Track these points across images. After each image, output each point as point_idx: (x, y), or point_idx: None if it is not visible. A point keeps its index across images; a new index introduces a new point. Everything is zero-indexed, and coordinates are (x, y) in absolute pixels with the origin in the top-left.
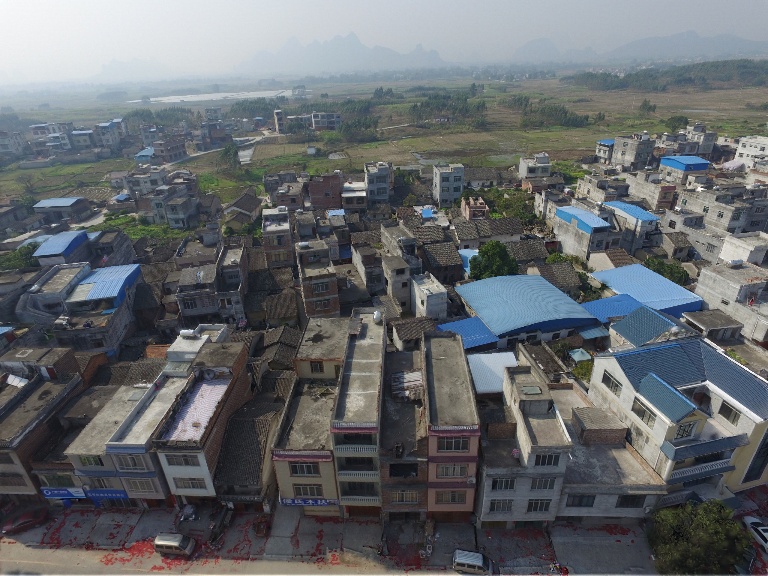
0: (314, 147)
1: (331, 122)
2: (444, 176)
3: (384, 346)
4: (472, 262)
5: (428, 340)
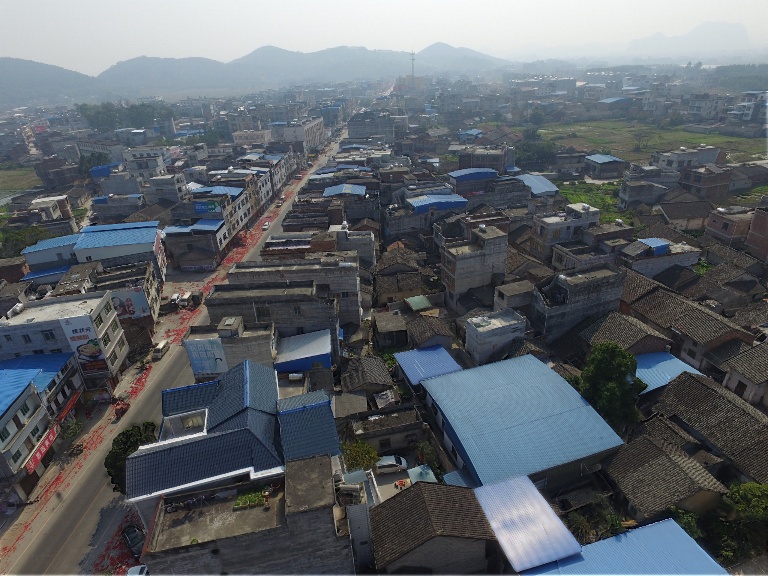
0: None
1: None
2: None
3: (321, 279)
4: None
5: (309, 286)
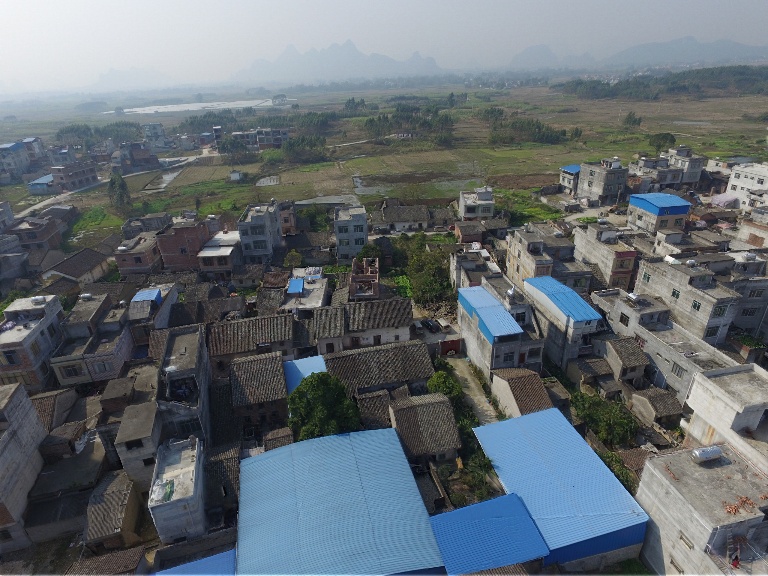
0: (238, 172)
1: (277, 139)
2: (340, 225)
3: None
4: (290, 403)
5: None
